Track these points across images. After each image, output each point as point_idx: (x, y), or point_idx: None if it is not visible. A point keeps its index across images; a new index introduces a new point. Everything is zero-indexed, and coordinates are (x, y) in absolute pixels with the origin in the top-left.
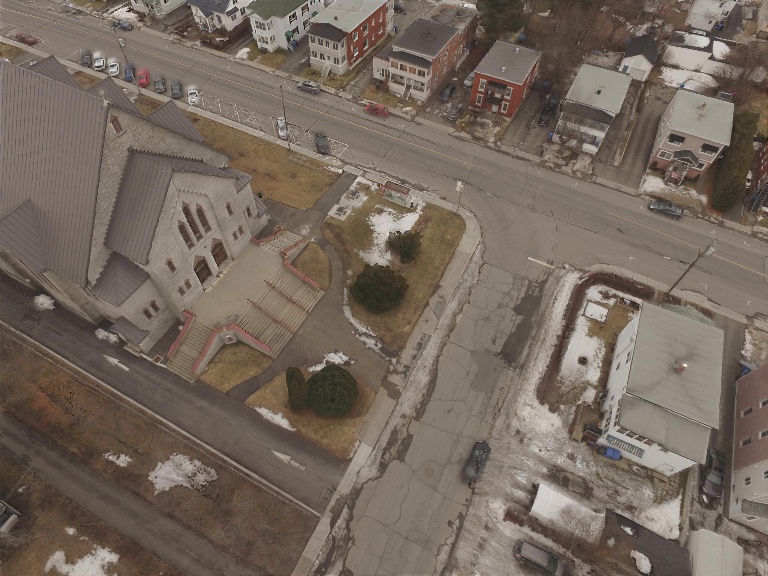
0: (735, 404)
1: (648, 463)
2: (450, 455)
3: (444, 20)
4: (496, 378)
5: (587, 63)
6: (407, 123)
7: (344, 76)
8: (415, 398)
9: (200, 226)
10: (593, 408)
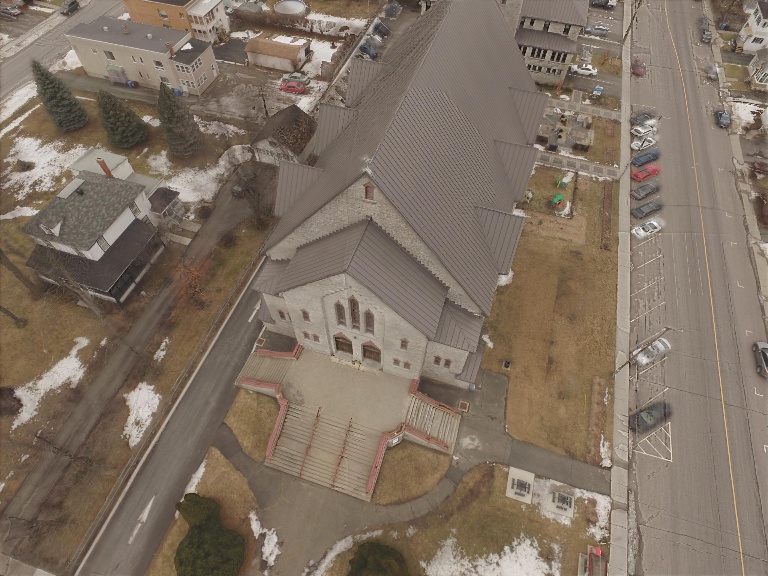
0: None
1: None
2: None
3: None
4: None
5: None
6: None
7: None
8: None
9: (362, 323)
10: None
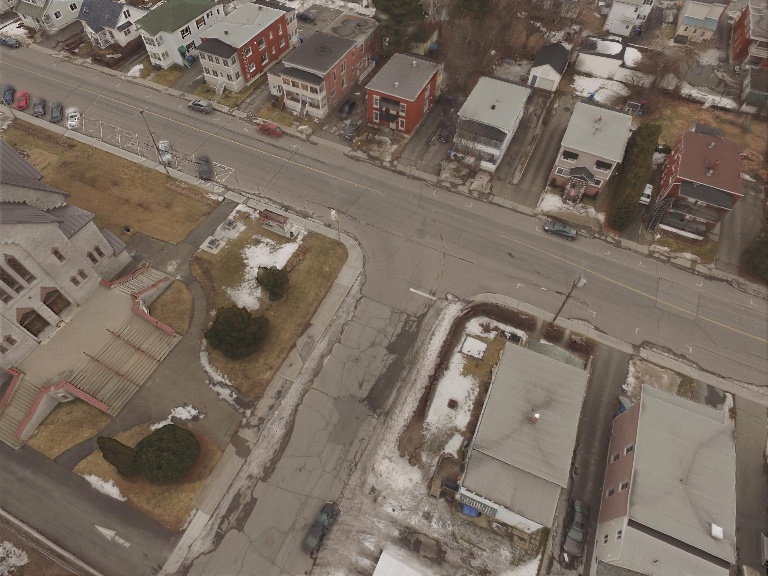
0: (609, 446)
1: (507, 520)
2: (295, 520)
3: (344, 32)
4: (357, 428)
5: (488, 75)
6: (301, 143)
7: (240, 93)
8: (265, 455)
9: (17, 277)
10: (457, 458)
